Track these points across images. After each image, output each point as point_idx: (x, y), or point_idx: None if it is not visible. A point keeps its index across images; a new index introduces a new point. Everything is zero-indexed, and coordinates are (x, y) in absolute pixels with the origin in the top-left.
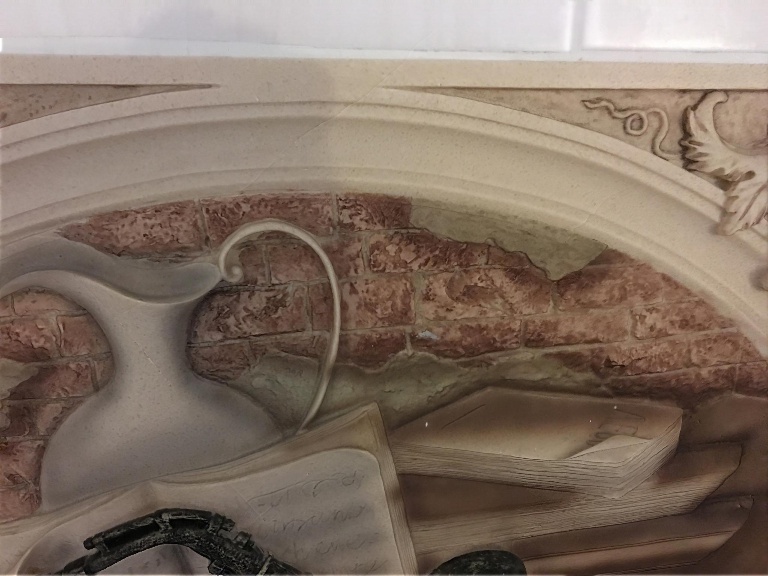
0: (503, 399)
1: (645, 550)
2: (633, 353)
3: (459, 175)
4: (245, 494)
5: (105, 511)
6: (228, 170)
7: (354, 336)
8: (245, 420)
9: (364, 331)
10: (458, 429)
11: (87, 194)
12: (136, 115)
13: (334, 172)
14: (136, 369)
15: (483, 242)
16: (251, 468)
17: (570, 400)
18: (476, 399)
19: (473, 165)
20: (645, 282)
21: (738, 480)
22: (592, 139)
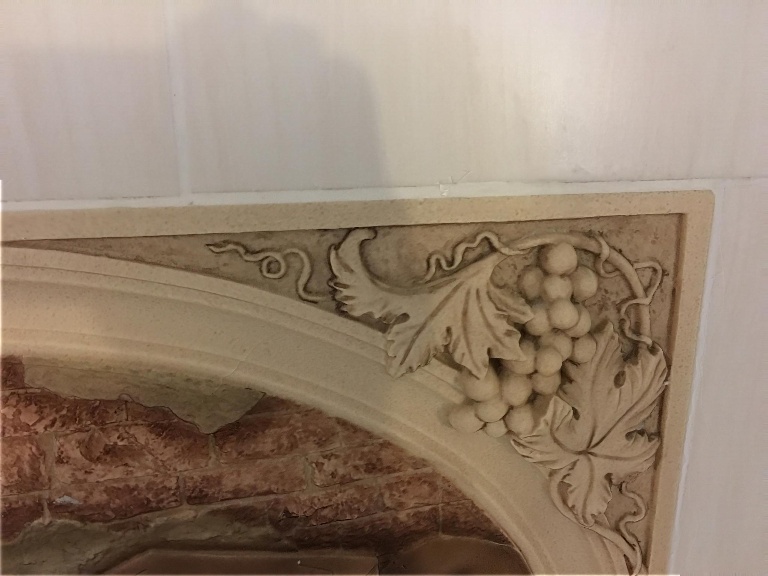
0: (168, 561)
1: None
2: (315, 502)
3: (76, 329)
4: None
5: None
6: None
7: None
8: None
9: None
10: None
11: None
12: None
13: None
14: None
15: (116, 398)
16: None
17: (246, 558)
18: (136, 564)
19: (93, 317)
20: (317, 428)
21: None
22: (218, 287)
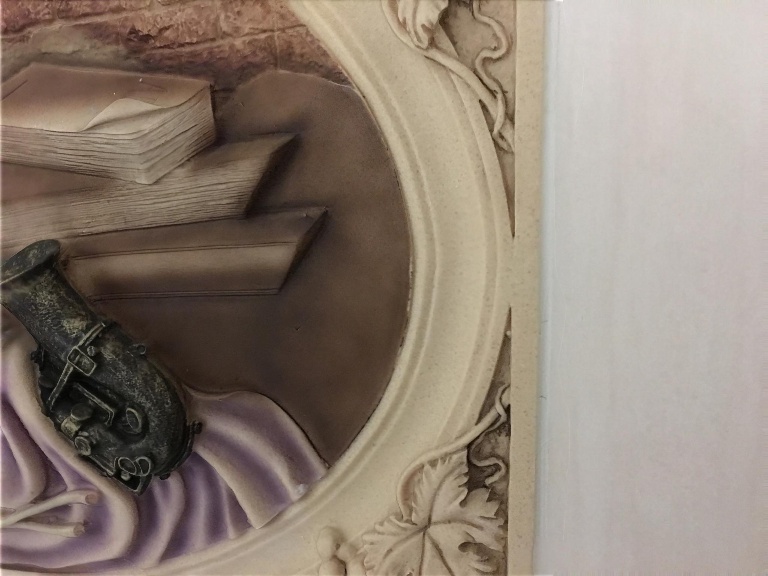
0: (44, 75)
1: (200, 259)
2: (158, 21)
3: None
4: None
5: None
6: None
7: None
8: None
9: None
10: (6, 105)
11: None
12: None
13: None
14: None
15: None
16: None
17: (100, 74)
18: (21, 75)
19: None
20: None
21: (305, 184)
22: None
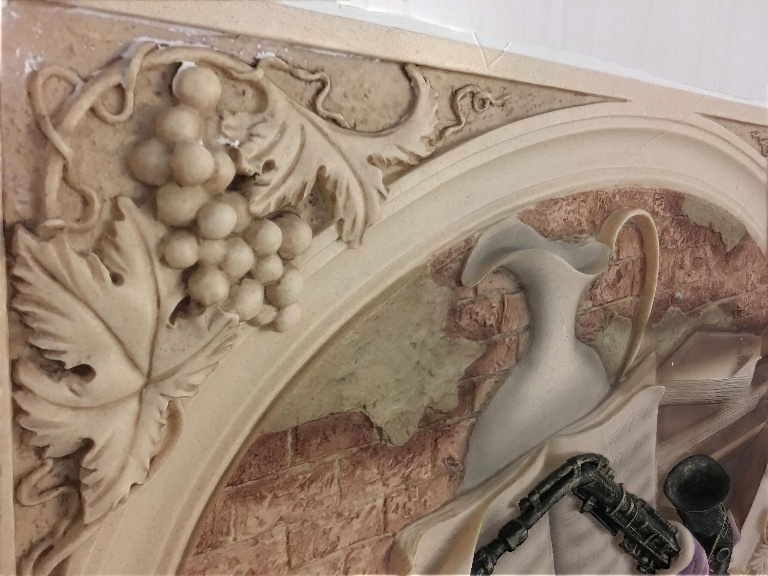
0: (702, 340)
1: None
2: (745, 301)
3: (703, 178)
4: (607, 435)
5: (532, 471)
6: (612, 167)
7: None
8: (599, 374)
9: None
10: None
11: (539, 183)
12: (589, 118)
13: (656, 172)
14: (554, 336)
15: None
16: (607, 413)
17: (726, 336)
18: (692, 341)
19: (706, 171)
20: (753, 253)
21: None
22: (758, 157)
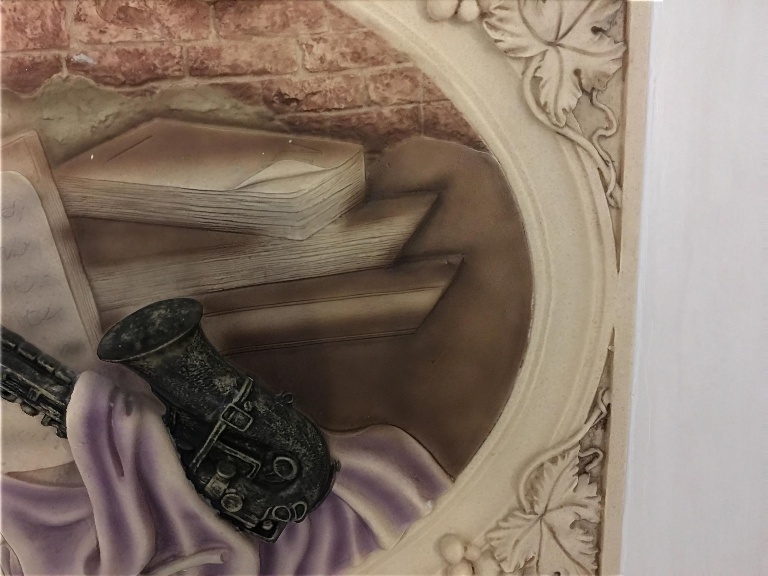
0: (172, 131)
1: (347, 307)
2: (305, 86)
3: None
4: None
5: None
6: None
7: (6, 58)
8: None
9: (17, 54)
10: (125, 161)
11: None
12: None
13: None
14: None
15: None
16: None
17: (242, 133)
18: (143, 131)
19: None
20: (307, 9)
21: (443, 236)
22: None
